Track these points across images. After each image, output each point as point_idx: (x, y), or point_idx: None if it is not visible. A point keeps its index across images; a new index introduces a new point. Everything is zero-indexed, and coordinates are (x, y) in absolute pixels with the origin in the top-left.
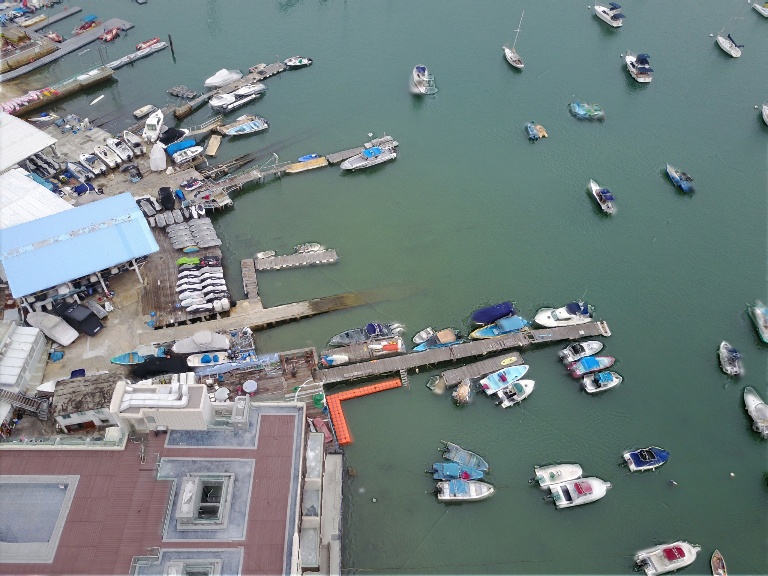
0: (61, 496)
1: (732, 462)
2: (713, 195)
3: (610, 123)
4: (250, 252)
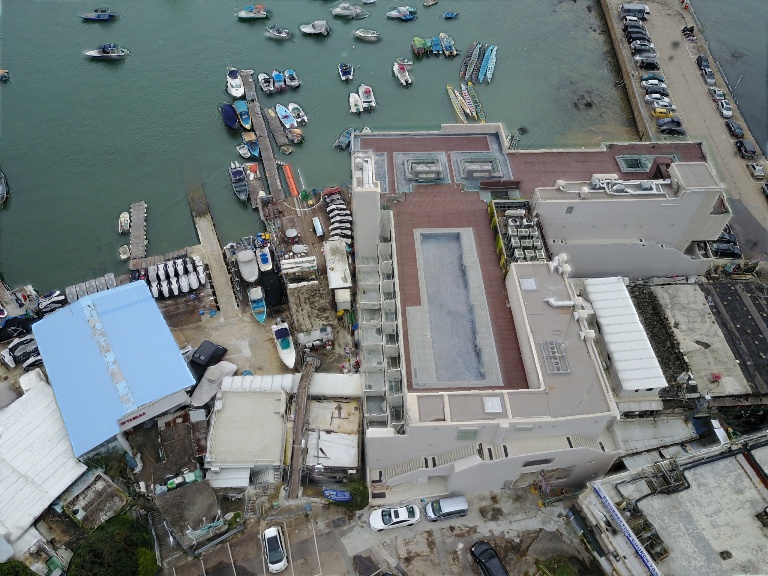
0: (426, 242)
1: (346, 46)
2: (122, 7)
3: (6, 34)
4: (115, 268)
